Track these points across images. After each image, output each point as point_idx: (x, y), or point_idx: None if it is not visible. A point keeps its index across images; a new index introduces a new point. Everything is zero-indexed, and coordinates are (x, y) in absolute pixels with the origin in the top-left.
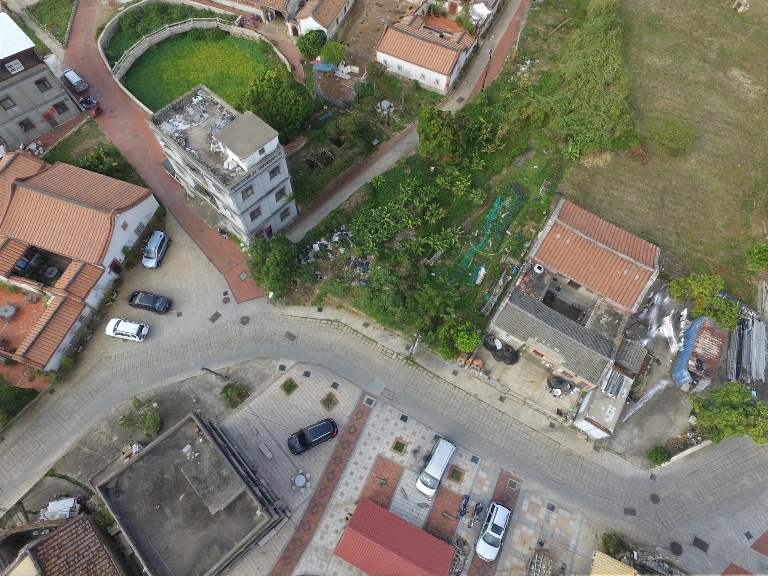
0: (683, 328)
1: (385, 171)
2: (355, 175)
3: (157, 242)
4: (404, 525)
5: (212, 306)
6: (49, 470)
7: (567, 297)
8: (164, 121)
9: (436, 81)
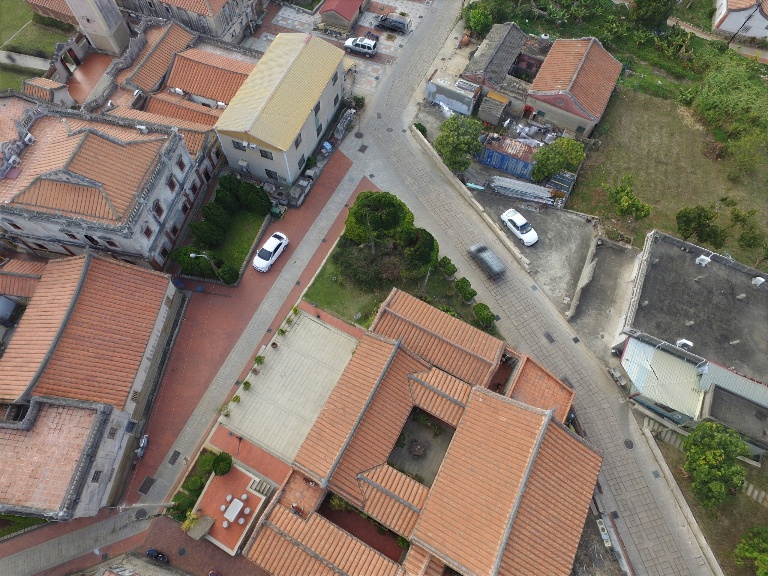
0: None
1: None
2: None
3: None
4: (360, 0)
5: None
6: None
7: None
8: None
9: None
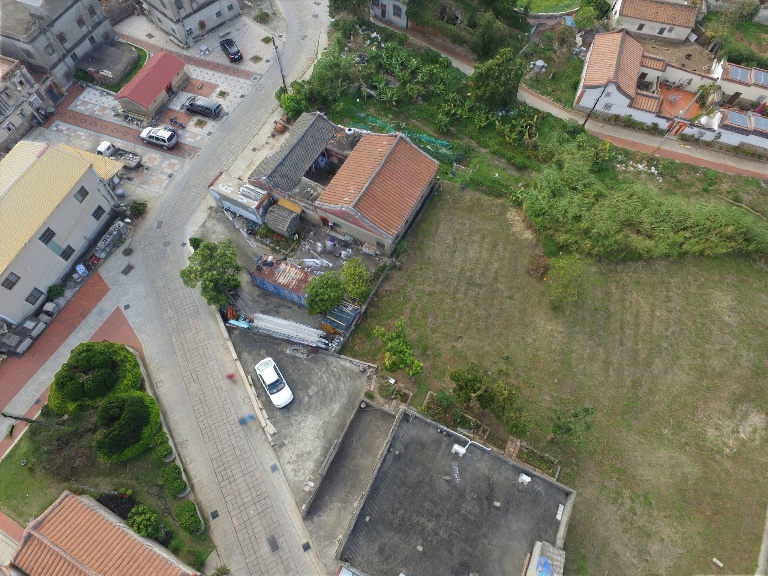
0: None
1: (462, 71)
2: (454, 56)
3: None
4: (165, 82)
5: (325, 1)
6: None
7: None
8: None
9: None
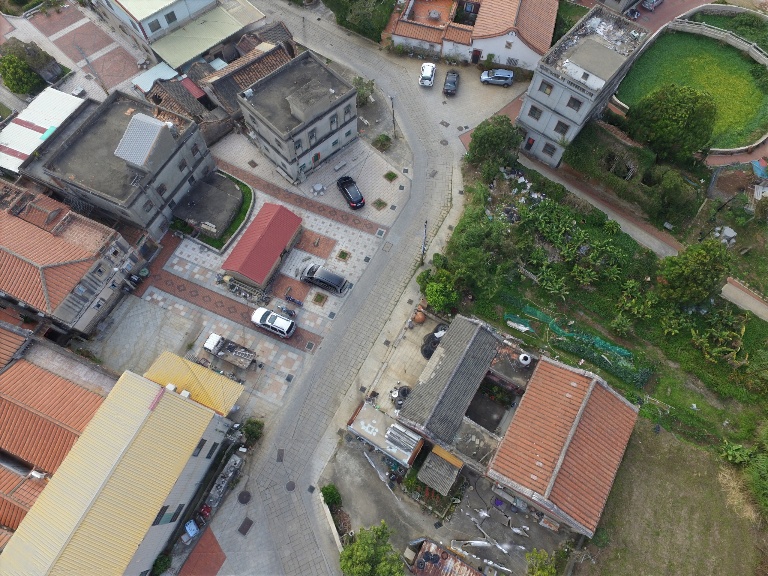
0: (486, 570)
1: (632, 237)
2: (618, 211)
3: (503, 74)
4: (280, 247)
5: (454, 121)
6: (330, 59)
7: (508, 421)
8: (601, 19)
9: None
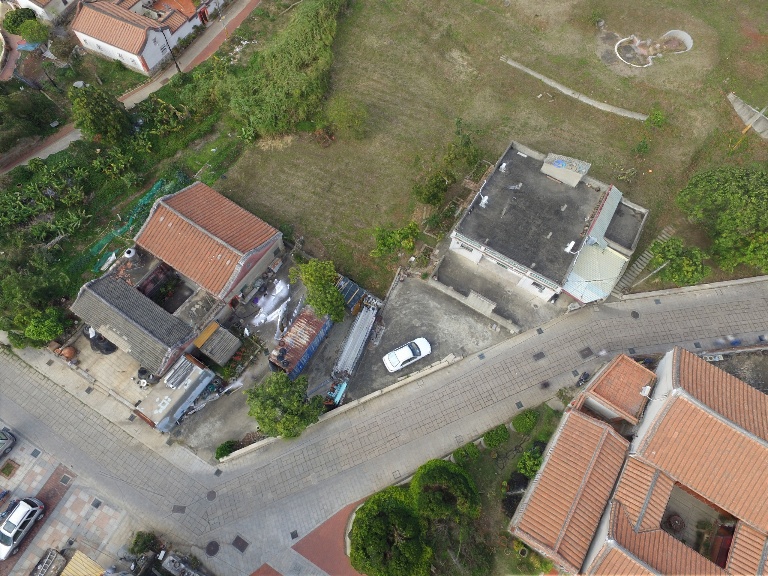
0: None
1: None
2: (24, 158)
3: None
4: None
5: None
6: None
7: (194, 284)
8: None
9: (132, 61)
